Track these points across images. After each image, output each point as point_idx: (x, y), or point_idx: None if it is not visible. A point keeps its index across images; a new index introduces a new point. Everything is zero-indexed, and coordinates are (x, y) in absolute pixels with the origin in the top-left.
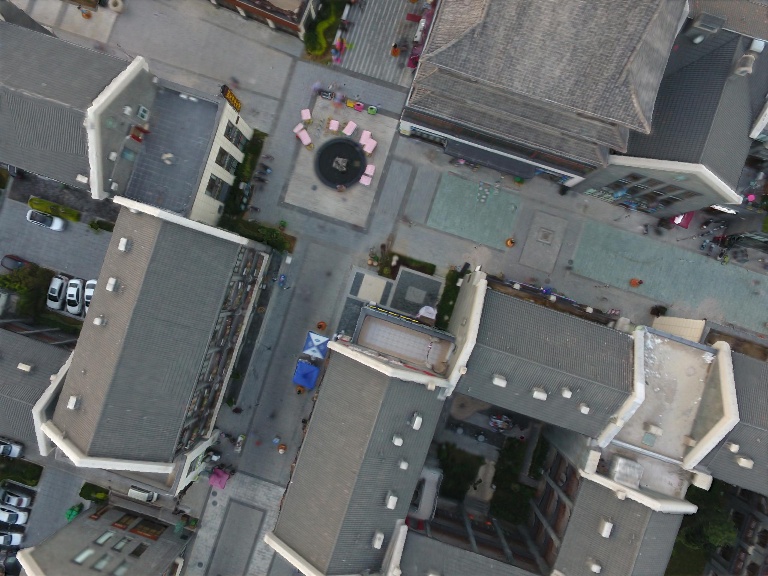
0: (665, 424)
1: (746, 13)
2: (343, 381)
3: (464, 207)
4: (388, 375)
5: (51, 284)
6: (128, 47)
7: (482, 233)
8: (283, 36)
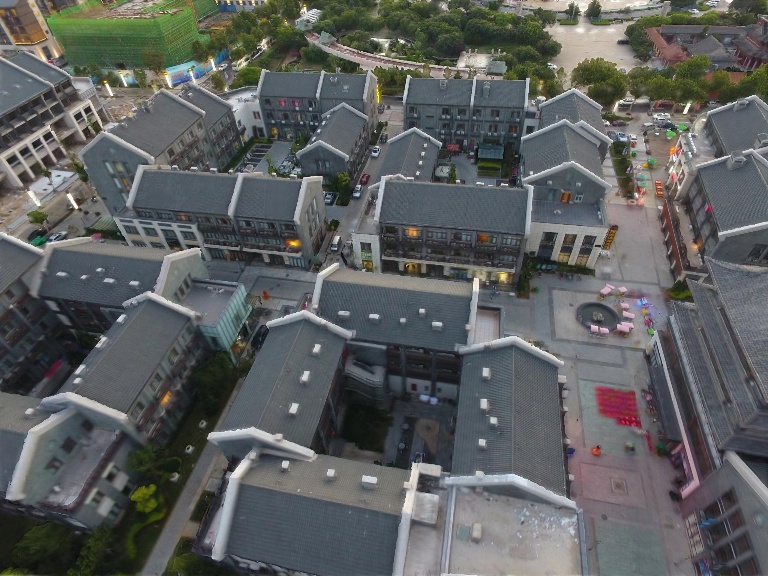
0: (484, 550)
1: None
2: (454, 285)
3: (609, 407)
4: (473, 290)
5: None
6: (610, 211)
7: (593, 425)
8: (670, 277)
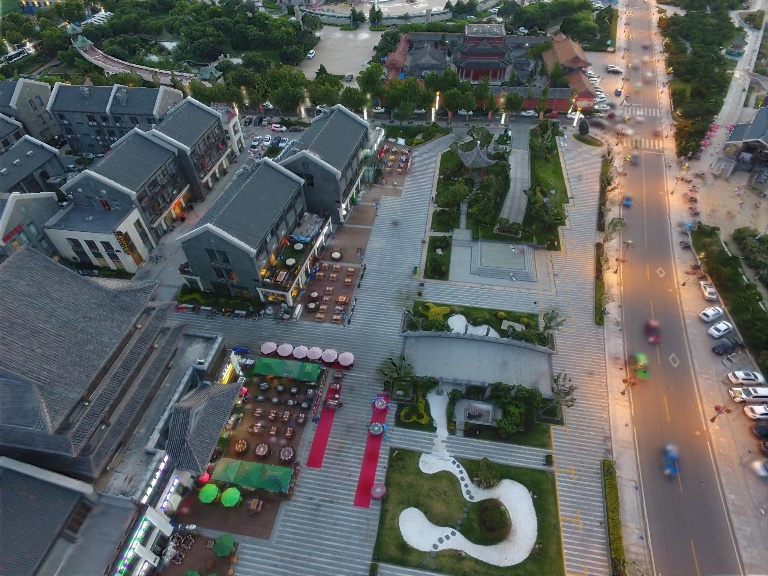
0: None
1: (3, 558)
2: None
3: None
4: None
5: (66, 202)
6: None
7: None
8: None
